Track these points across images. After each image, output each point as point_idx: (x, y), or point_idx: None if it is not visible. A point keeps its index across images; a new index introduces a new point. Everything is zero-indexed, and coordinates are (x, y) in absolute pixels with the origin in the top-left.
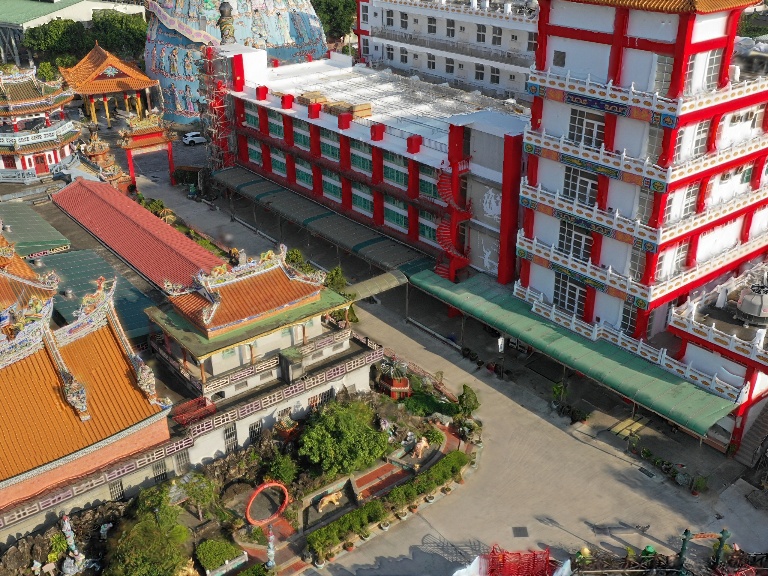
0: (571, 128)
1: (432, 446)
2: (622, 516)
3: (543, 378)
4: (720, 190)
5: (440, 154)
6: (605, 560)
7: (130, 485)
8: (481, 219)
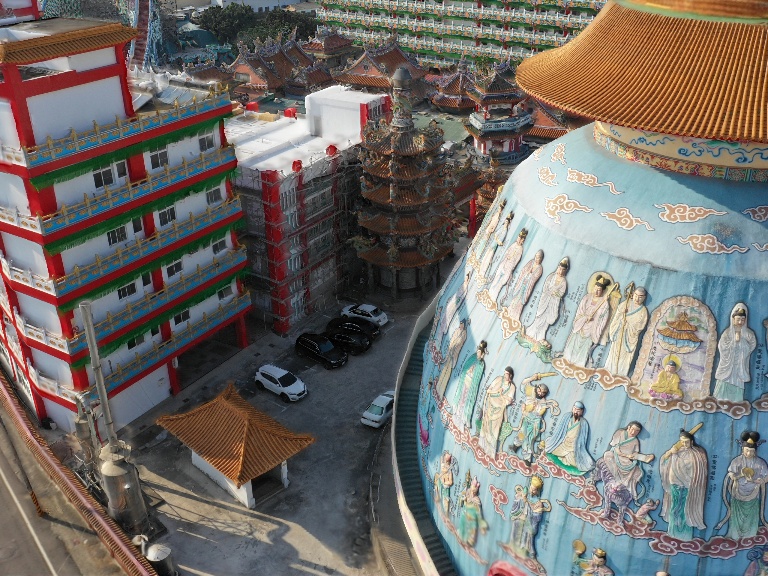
0: None
1: None
2: None
3: None
4: None
5: None
6: None
7: None
8: None
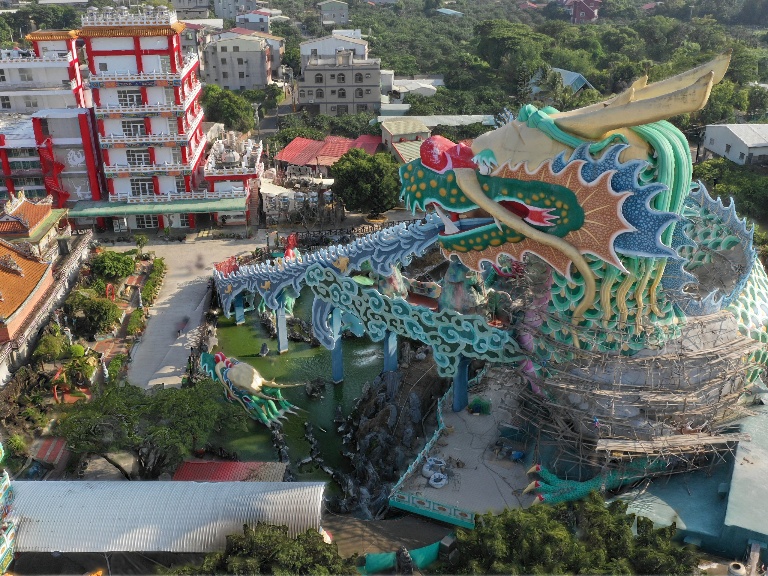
0: (120, 101)
1: (140, 265)
2: (236, 252)
3: (148, 235)
4: (189, 117)
5: (24, 141)
6: (247, 258)
7: (50, 308)
8: (68, 170)
